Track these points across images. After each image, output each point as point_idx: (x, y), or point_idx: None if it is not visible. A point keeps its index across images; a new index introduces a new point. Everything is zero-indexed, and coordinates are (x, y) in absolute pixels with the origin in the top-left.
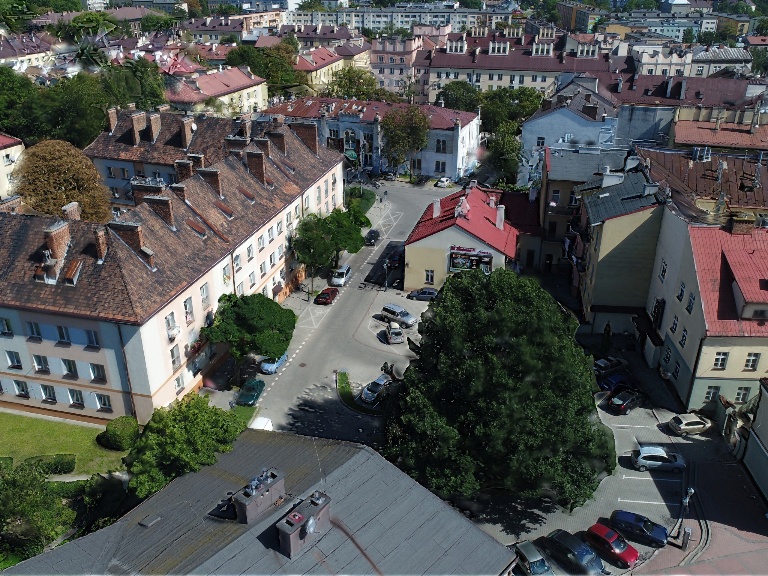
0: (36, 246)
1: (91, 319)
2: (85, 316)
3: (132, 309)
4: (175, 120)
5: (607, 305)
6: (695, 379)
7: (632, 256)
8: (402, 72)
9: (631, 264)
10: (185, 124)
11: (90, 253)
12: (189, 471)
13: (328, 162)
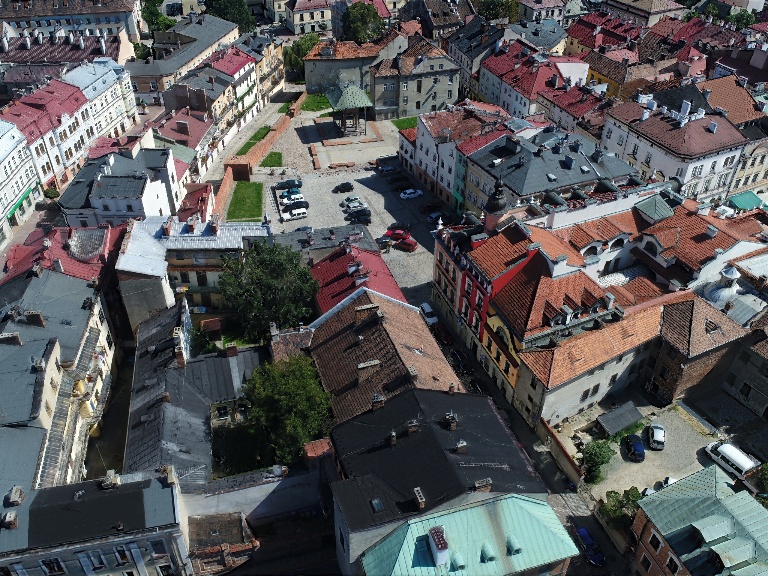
0: None
1: (118, 12)
2: (116, 12)
3: (129, 8)
4: None
5: (252, 4)
6: (275, 13)
7: None
8: None
9: None
10: None
11: None
12: None
13: None
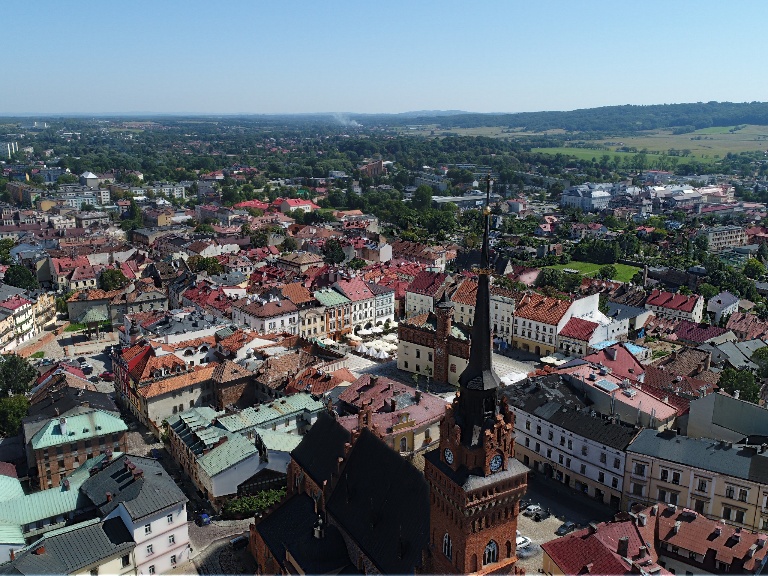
0: None
1: None
2: None
3: None
4: None
5: (42, 281)
6: (59, 284)
7: (45, 269)
8: None
9: (45, 271)
10: None
11: None
12: None
13: None
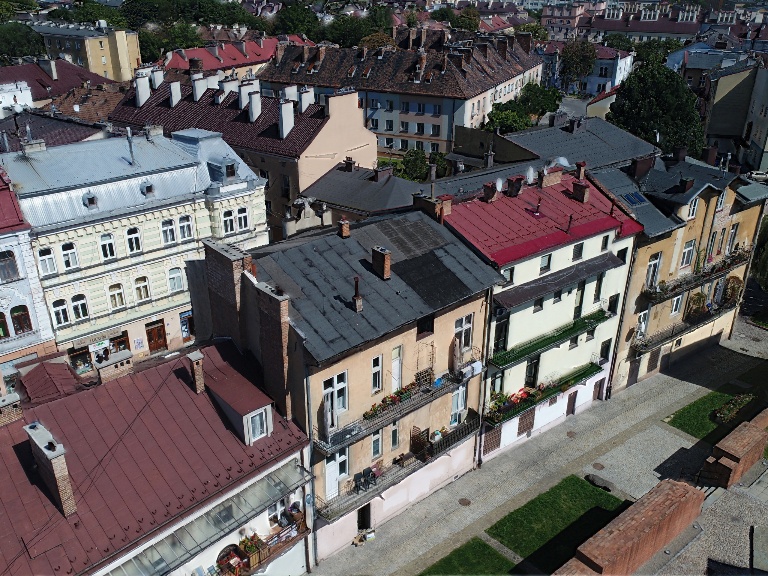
0: (408, 66)
1: (441, 97)
2: (438, 96)
3: (462, 92)
4: (435, 33)
5: (717, 134)
6: (764, 152)
7: (736, 101)
8: (567, 32)
9: (735, 106)
10: (445, 34)
11: (437, 68)
12: (515, 130)
13: (536, 60)
